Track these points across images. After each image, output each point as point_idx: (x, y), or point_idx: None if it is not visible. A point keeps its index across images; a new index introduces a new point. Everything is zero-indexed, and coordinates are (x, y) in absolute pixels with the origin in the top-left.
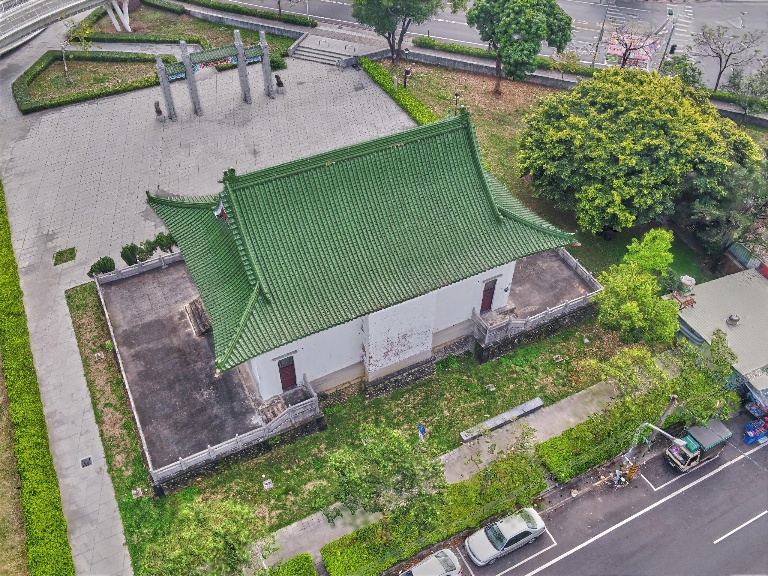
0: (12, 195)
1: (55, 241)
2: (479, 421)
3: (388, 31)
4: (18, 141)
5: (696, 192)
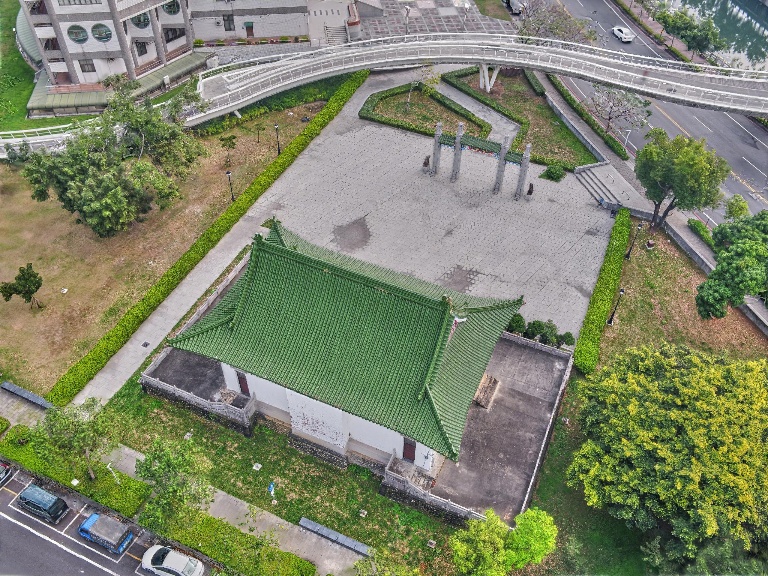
0: (294, 168)
1: (278, 211)
2: (326, 524)
3: None
4: (337, 134)
5: None
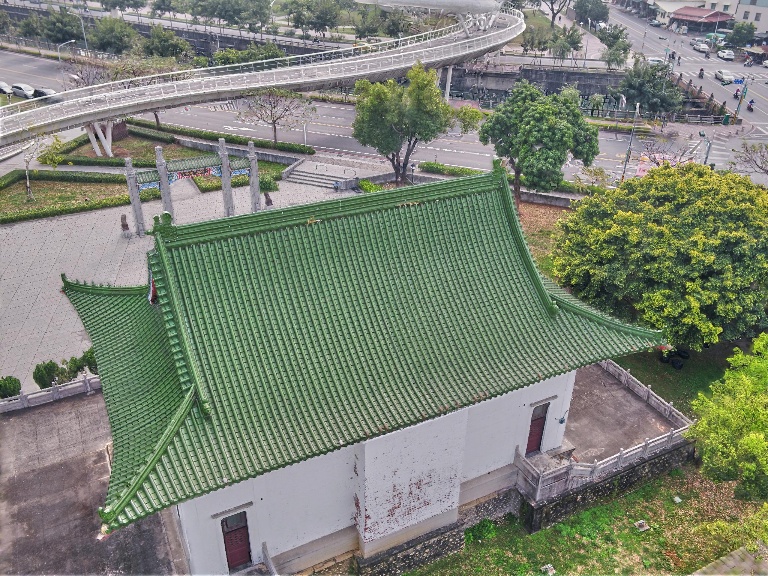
0: None
1: None
2: None
3: (392, 152)
4: None
5: None
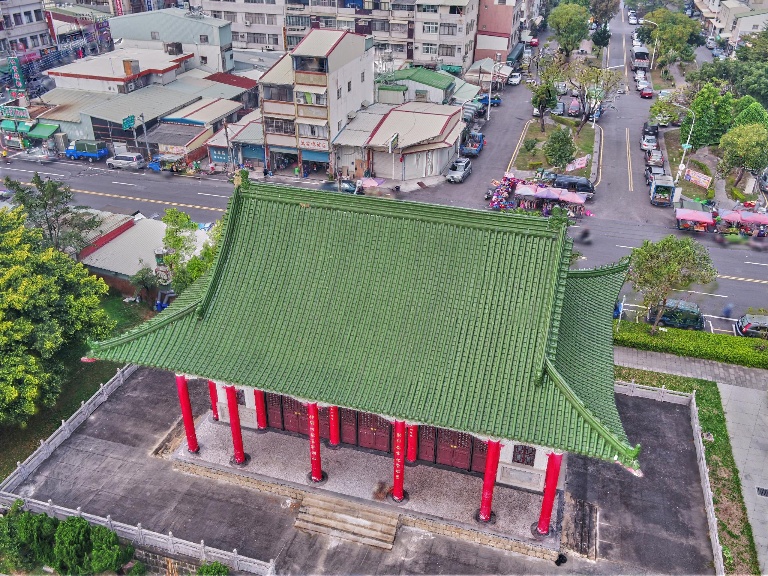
0: None
1: None
2: None
3: None
4: None
5: None
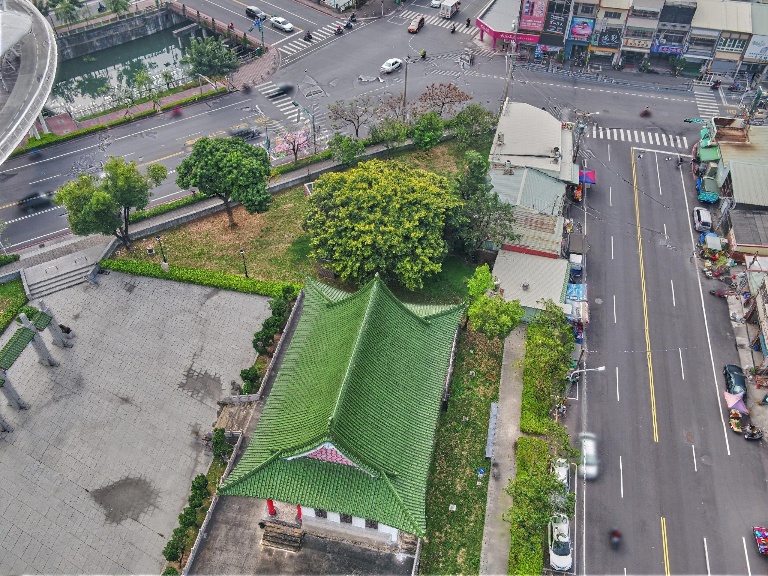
0: None
1: None
2: (482, 442)
3: None
4: None
5: (452, 228)
